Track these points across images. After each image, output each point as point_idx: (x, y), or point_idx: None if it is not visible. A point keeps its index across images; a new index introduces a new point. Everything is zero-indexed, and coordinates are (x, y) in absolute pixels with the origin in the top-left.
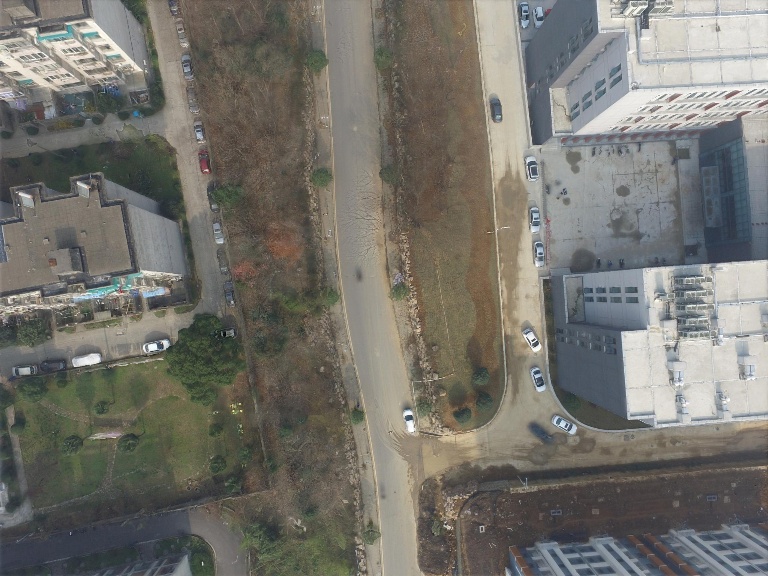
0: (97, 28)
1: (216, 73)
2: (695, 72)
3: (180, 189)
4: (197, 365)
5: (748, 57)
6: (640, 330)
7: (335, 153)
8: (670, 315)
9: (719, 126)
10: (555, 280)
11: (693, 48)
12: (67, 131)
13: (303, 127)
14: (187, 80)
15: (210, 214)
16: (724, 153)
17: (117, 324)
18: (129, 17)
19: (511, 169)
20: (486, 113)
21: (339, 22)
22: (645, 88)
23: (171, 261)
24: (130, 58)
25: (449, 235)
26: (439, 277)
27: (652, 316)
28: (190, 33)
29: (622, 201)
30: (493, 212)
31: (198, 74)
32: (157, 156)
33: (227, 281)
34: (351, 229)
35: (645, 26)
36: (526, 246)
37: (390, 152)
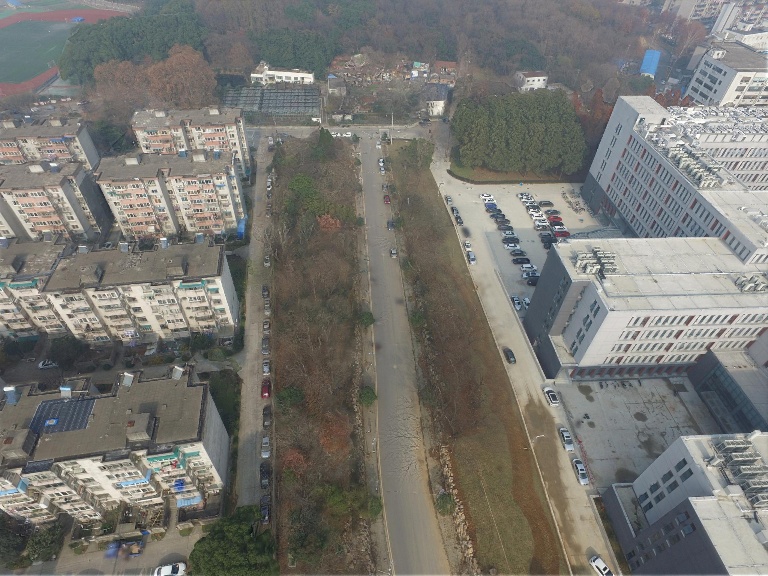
0: (220, 285)
1: (288, 329)
2: (652, 303)
3: (239, 410)
4: (230, 552)
5: (686, 295)
6: (707, 496)
7: (378, 384)
8: (731, 483)
9: (698, 361)
10: (606, 496)
11: (643, 290)
12: (157, 366)
13: (353, 362)
14: (264, 334)
15: (261, 432)
16: (713, 379)
17: (135, 543)
18: (235, 293)
19: (533, 398)
20: (502, 357)
21: (382, 303)
22: (619, 310)
23: (219, 462)
24: (230, 312)
25: (488, 447)
26: (484, 488)
27: (712, 479)
28: (274, 304)
29: (643, 425)
30: (525, 431)
31: (275, 327)
32: (226, 385)
33: (265, 495)
34: (392, 446)
35: (603, 278)
36: (565, 465)
37: (425, 383)
